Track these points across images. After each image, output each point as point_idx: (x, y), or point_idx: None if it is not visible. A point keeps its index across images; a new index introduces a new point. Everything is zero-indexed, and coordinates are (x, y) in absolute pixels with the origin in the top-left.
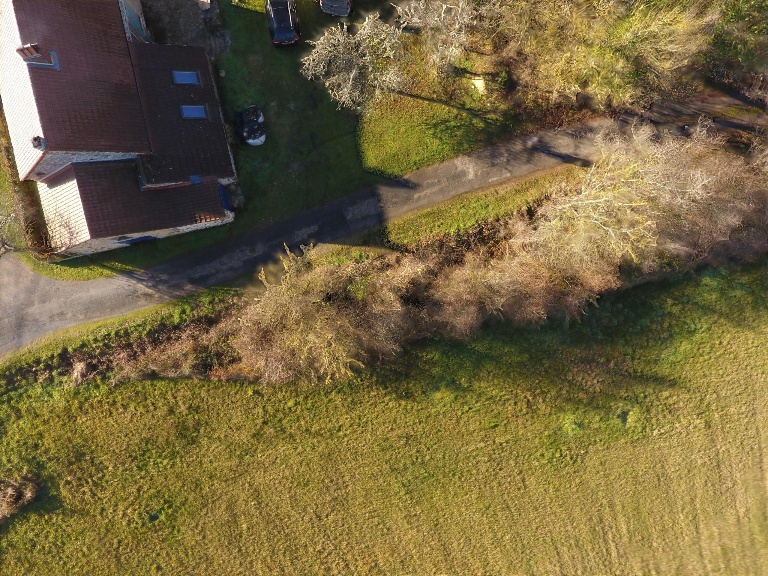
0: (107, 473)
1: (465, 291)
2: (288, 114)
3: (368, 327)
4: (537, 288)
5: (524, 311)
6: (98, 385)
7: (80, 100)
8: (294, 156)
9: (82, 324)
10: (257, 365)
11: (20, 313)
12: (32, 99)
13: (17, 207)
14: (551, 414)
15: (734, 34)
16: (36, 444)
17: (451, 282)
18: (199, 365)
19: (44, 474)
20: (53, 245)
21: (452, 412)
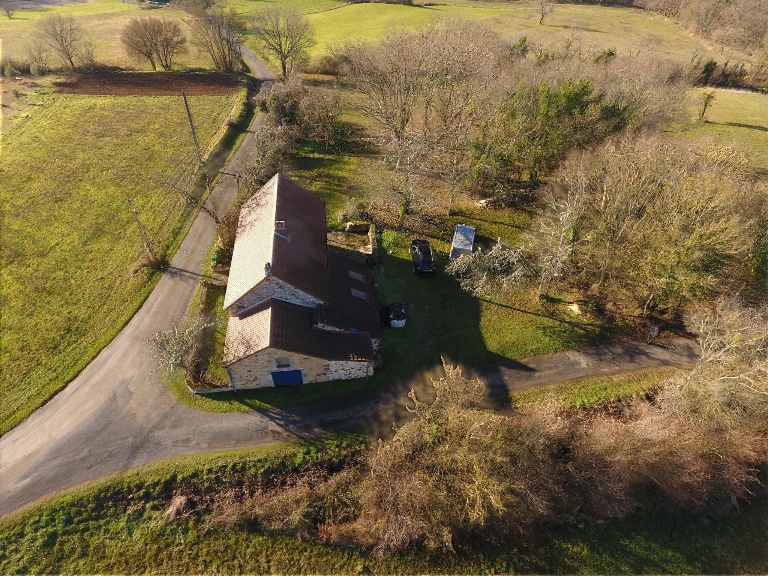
0: None
1: (612, 438)
2: (424, 312)
3: (510, 476)
4: (687, 445)
5: (681, 475)
6: (188, 529)
7: (296, 260)
8: (428, 336)
9: (203, 453)
10: (376, 525)
11: (147, 435)
12: (270, 249)
13: (191, 347)
14: None
15: None
16: None
17: (593, 432)
18: (311, 515)
19: None
20: (224, 360)
21: None
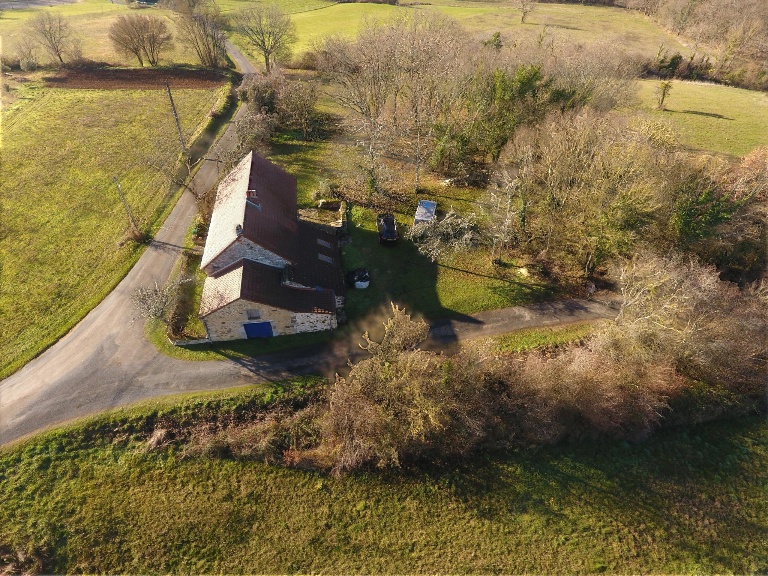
0: (128, 567)
1: (540, 370)
2: (386, 275)
3: None
4: (606, 375)
5: (600, 401)
6: (167, 456)
7: (266, 225)
8: (389, 295)
9: (181, 393)
10: (334, 450)
11: (131, 379)
12: (242, 215)
13: (172, 306)
14: (668, 559)
15: (690, 226)
16: (73, 510)
17: (526, 367)
18: (276, 443)
19: (59, 553)
20: (200, 313)
21: (546, 542)
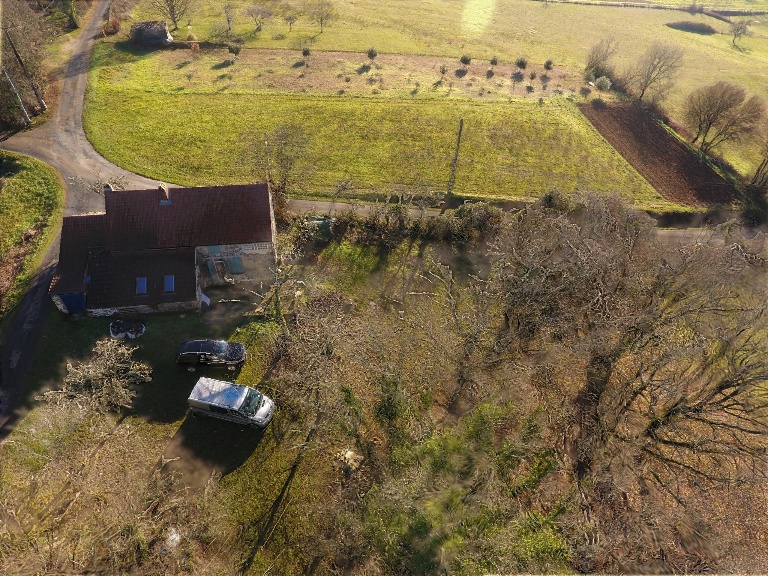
0: None
1: None
2: None
3: None
4: None
5: None
6: None
7: (141, 213)
8: (85, 355)
9: (56, 234)
10: None
11: (86, 211)
12: None
13: None
14: None
15: None
16: (3, 213)
17: None
18: None
19: None
20: (90, 212)
21: None
